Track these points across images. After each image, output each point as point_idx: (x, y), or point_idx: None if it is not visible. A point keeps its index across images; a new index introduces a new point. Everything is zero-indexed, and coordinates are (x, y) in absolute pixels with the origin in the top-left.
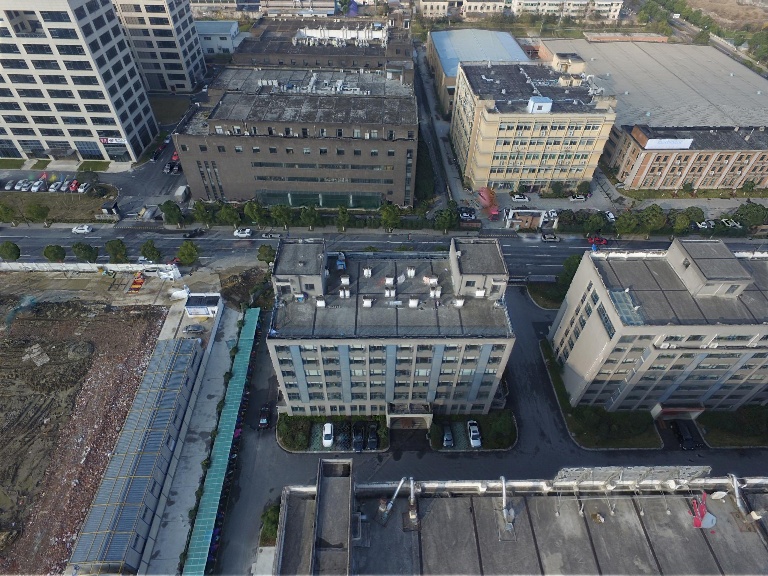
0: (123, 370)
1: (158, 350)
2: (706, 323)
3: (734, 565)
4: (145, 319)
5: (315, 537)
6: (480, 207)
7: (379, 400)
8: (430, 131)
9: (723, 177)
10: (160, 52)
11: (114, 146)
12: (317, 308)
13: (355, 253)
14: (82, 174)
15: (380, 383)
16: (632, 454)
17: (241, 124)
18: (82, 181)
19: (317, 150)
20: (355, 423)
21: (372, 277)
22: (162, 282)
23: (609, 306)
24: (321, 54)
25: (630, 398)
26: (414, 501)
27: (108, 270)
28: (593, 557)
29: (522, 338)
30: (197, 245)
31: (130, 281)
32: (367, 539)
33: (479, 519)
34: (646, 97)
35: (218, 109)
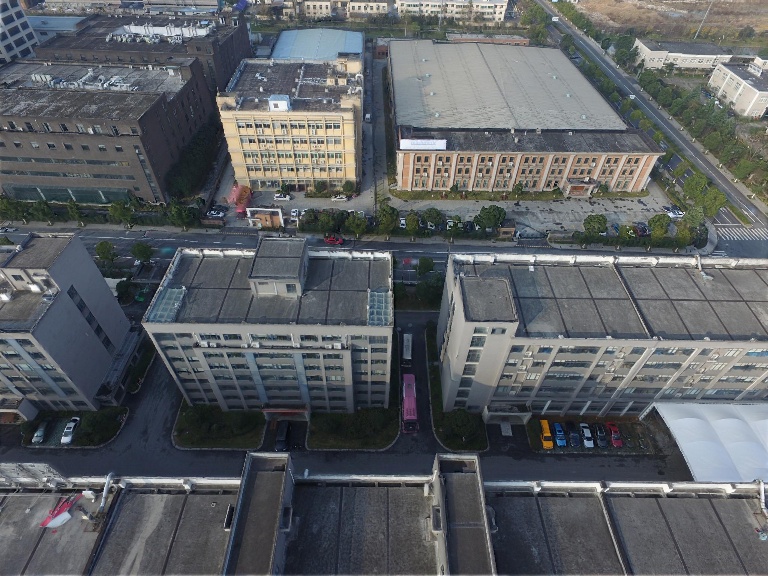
0: None
1: None
2: None
3: (43, 565)
4: None
5: None
6: None
7: None
8: None
9: (494, 179)
10: None
11: None
12: None
13: None
14: None
15: None
16: (222, 454)
17: None
18: None
19: (45, 144)
20: None
21: None
22: None
23: None
24: (122, 50)
25: (231, 398)
26: None
27: None
28: None
29: None
30: None
31: None
32: None
33: None
34: (449, 98)
35: None
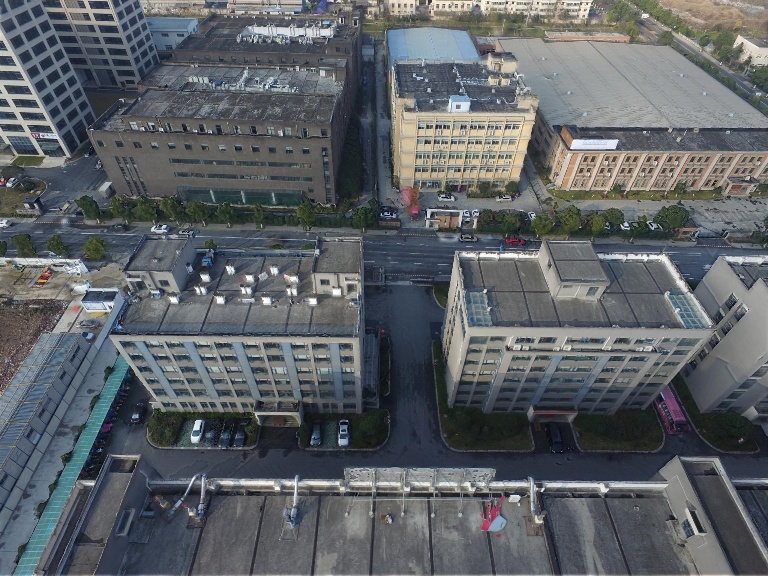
0: (9, 363)
1: (39, 344)
2: (558, 325)
3: (509, 569)
4: (42, 313)
5: (77, 532)
6: (404, 206)
7: (247, 397)
8: (372, 129)
9: (654, 179)
10: (107, 48)
11: (47, 141)
12: (171, 304)
13: (225, 250)
14: (6, 169)
15: (241, 380)
16: (500, 456)
17: (155, 120)
18: (6, 176)
19: (232, 147)
20: (227, 420)
21: (236, 274)
22: (68, 277)
23: (463, 307)
24: (261, 51)
25: (502, 400)
26: (204, 498)
27: (17, 264)
28: (369, 558)
29: (416, 338)
30: (112, 240)
31: (37, 275)
32: (146, 535)
33: (266, 518)
34: (588, 97)
35: (135, 105)
